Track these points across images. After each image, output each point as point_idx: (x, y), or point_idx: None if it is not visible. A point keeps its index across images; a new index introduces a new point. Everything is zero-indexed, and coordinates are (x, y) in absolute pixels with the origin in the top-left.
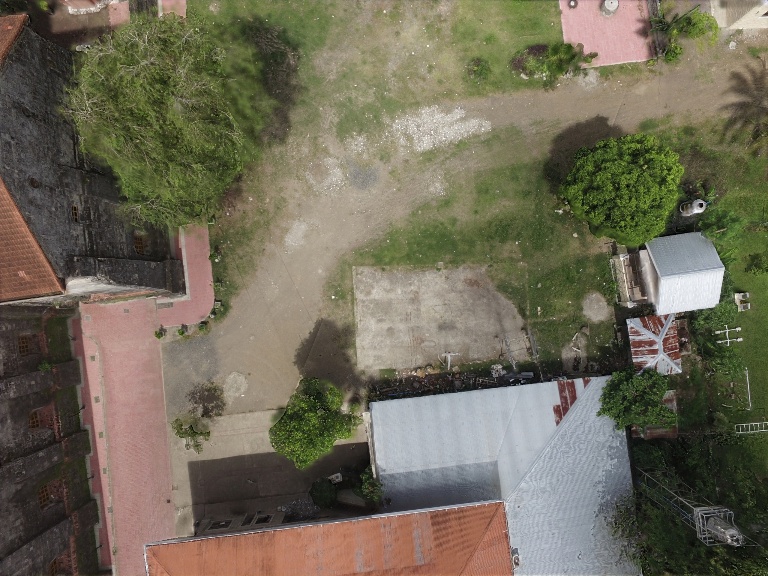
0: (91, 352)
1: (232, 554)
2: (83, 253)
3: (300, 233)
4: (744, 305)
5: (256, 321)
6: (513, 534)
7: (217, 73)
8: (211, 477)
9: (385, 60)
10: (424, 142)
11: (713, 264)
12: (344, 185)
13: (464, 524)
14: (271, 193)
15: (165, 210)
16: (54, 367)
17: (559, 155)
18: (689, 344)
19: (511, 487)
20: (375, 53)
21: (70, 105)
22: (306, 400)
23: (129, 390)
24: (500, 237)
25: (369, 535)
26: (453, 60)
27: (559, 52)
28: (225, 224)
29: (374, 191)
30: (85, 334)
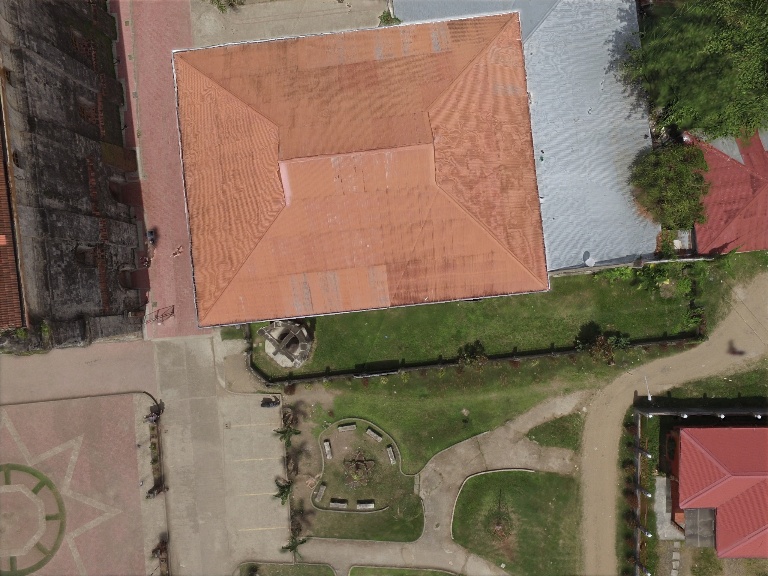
0: None
1: (257, 54)
2: None
3: None
4: None
5: None
6: None
7: None
8: None
9: None
10: None
11: None
12: None
13: (480, 27)
14: None
15: None
16: None
17: None
18: None
19: (524, 34)
20: None
21: None
22: None
23: None
24: None
25: (388, 37)
26: None
27: None
28: None
29: None
30: None
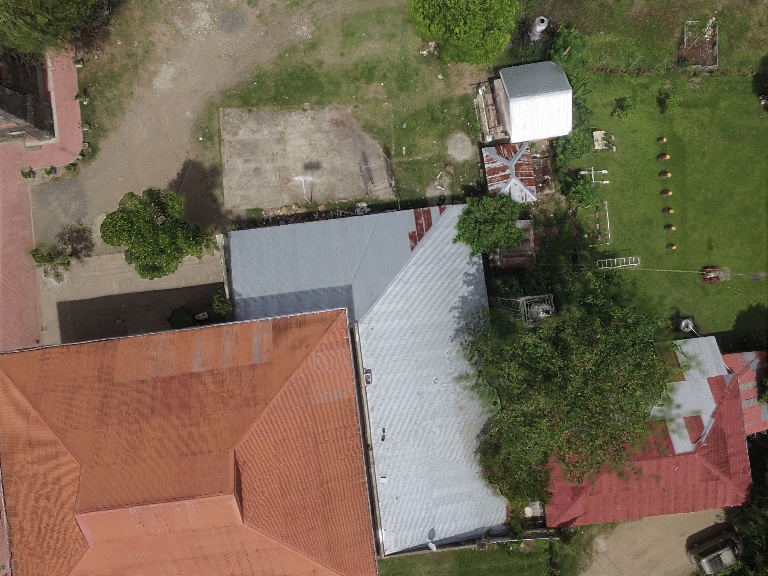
0: None
1: (74, 360)
2: None
3: (168, 76)
4: (605, 143)
5: (124, 163)
6: (366, 355)
7: None
8: (80, 317)
9: None
10: None
11: (561, 87)
12: (212, 29)
13: (304, 329)
14: (139, 37)
15: (1, 13)
16: None
17: None
18: (552, 182)
19: (364, 309)
20: None
21: None
22: (140, 198)
23: None
24: (366, 79)
25: (210, 340)
26: None
27: None
28: (93, 67)
29: (242, 35)
30: None
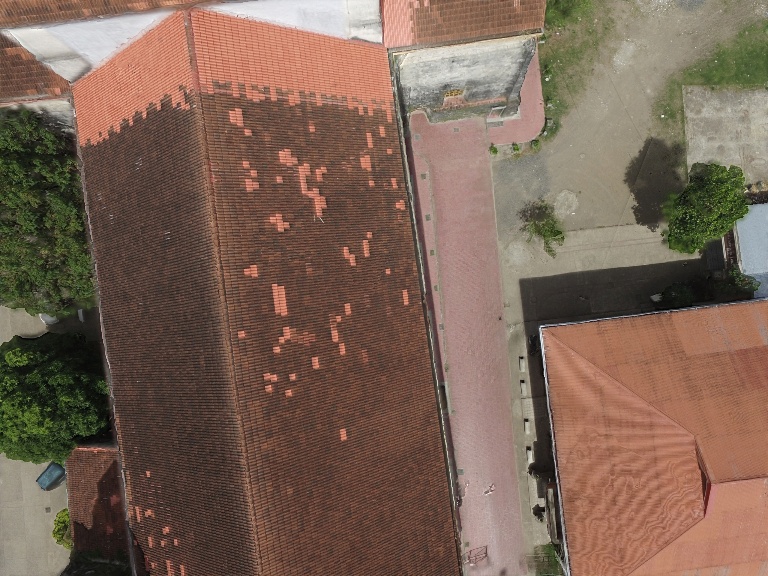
0: (422, 170)
1: (633, 332)
2: None
3: (628, 53)
4: None
5: (586, 140)
6: None
7: None
8: (543, 294)
9: None
10: None
11: None
12: (671, 6)
13: None
14: (599, 14)
15: None
16: None
17: None
18: None
19: None
20: None
21: None
22: None
23: (460, 208)
24: None
25: (767, 314)
26: None
27: None
28: (556, 43)
29: (700, 12)
30: (415, 153)
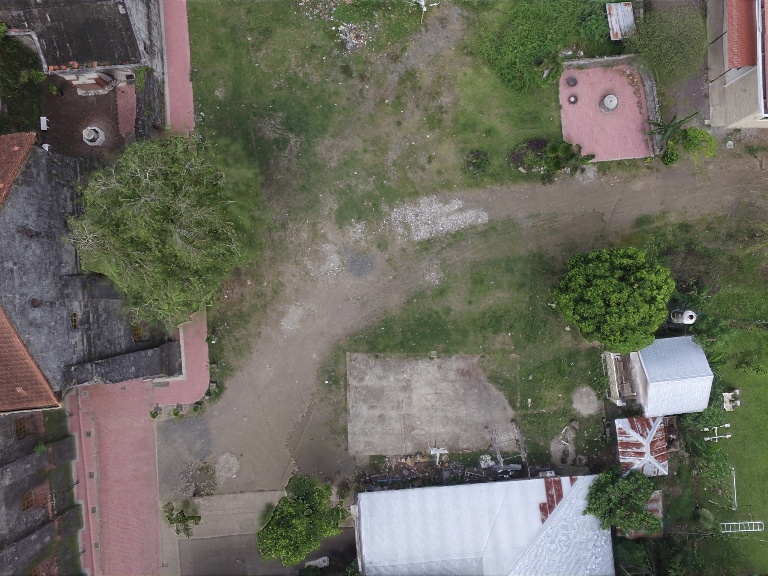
0: (87, 428)
1: None
2: (81, 359)
3: (296, 317)
4: (733, 405)
5: (250, 403)
6: None
7: (216, 197)
8: (200, 555)
9: (385, 149)
10: (421, 231)
11: (702, 371)
12: (341, 271)
13: None
14: (269, 277)
15: (163, 312)
16: (50, 446)
17: (554, 249)
18: (677, 441)
19: None
20: (376, 142)
21: (72, 235)
22: (294, 505)
23: (123, 466)
24: (493, 328)
25: None
26: (452, 151)
27: (557, 151)
28: (223, 306)
29: (370, 278)
30: (82, 410)
